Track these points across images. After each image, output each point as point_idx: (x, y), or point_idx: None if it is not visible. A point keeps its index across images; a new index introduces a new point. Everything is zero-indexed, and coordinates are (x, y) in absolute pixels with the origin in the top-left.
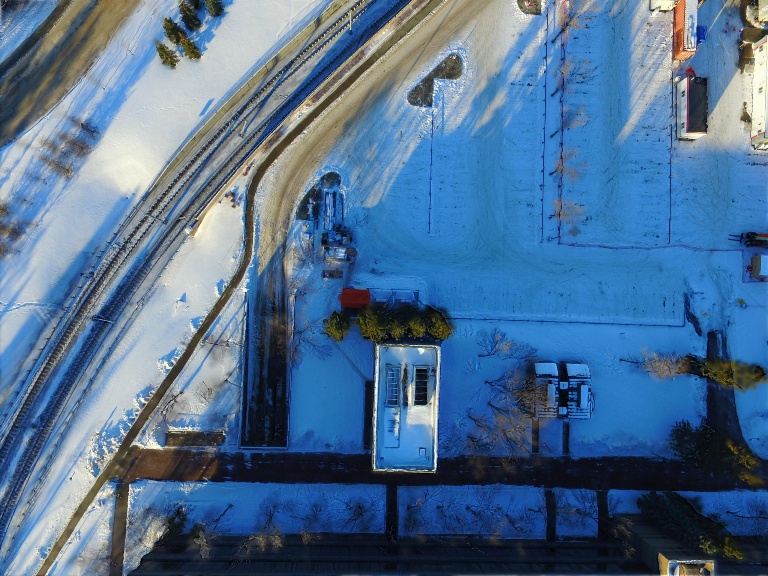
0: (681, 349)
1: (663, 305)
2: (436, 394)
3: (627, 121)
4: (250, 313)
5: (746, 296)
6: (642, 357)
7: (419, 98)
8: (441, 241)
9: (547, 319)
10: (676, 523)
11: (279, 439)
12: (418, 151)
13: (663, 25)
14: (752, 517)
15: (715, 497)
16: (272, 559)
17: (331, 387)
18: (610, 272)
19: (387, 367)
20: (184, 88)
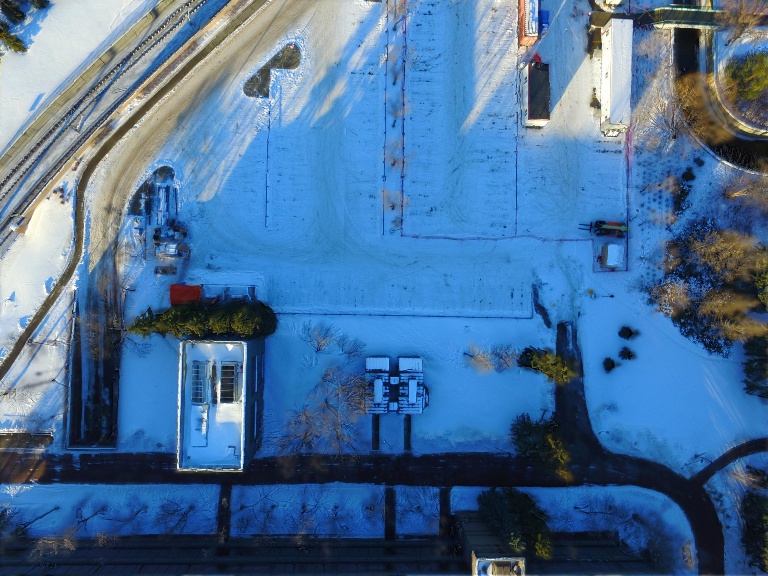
0: (525, 341)
1: (511, 297)
2: (242, 391)
3: (472, 109)
4: (81, 311)
5: (597, 286)
6: (478, 350)
7: (255, 89)
8: (279, 235)
9: (390, 313)
10: (499, 520)
11: (114, 440)
12: (255, 143)
13: (509, 10)
14: (592, 512)
15: (563, 492)
16: (80, 562)
17: (162, 386)
18: (456, 264)
19: (194, 364)
20: (11, 82)
